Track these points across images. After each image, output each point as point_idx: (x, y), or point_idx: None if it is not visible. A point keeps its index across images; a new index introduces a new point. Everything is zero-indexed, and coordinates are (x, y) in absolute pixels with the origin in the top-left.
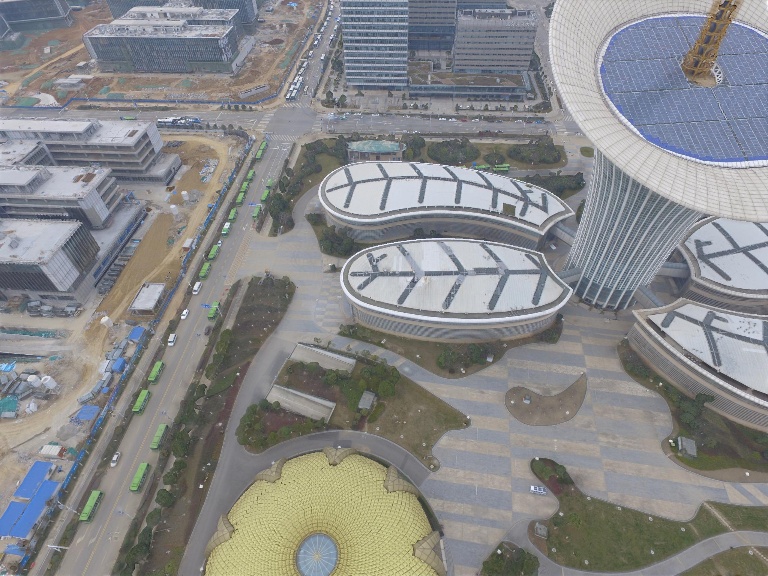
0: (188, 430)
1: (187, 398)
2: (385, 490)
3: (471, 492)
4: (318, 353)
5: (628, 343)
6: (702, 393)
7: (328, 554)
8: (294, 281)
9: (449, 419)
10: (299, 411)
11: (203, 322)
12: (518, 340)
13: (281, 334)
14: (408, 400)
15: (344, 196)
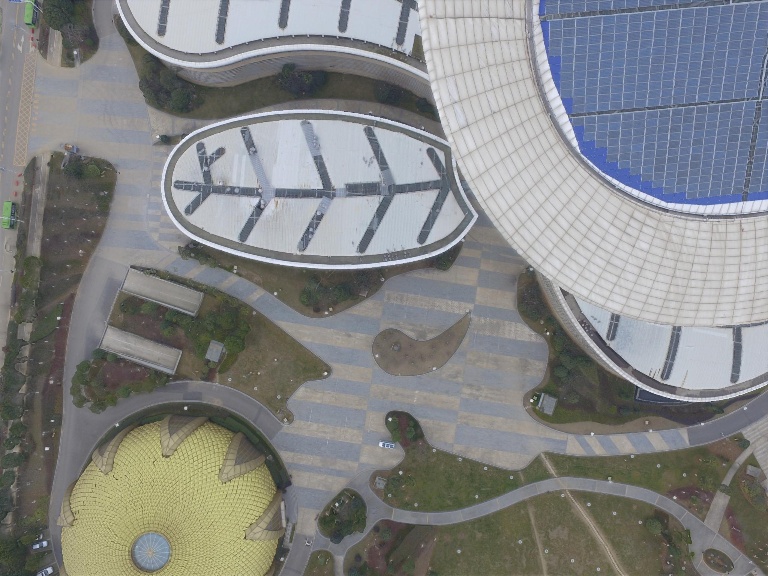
0: (16, 390)
1: (9, 343)
2: (219, 481)
3: (322, 445)
4: (157, 280)
5: (533, 273)
6: (587, 347)
7: (161, 550)
8: (112, 161)
9: (308, 368)
10: (143, 355)
11: (1, 231)
12: (403, 265)
13: (107, 252)
14: (264, 347)
15: (155, 6)
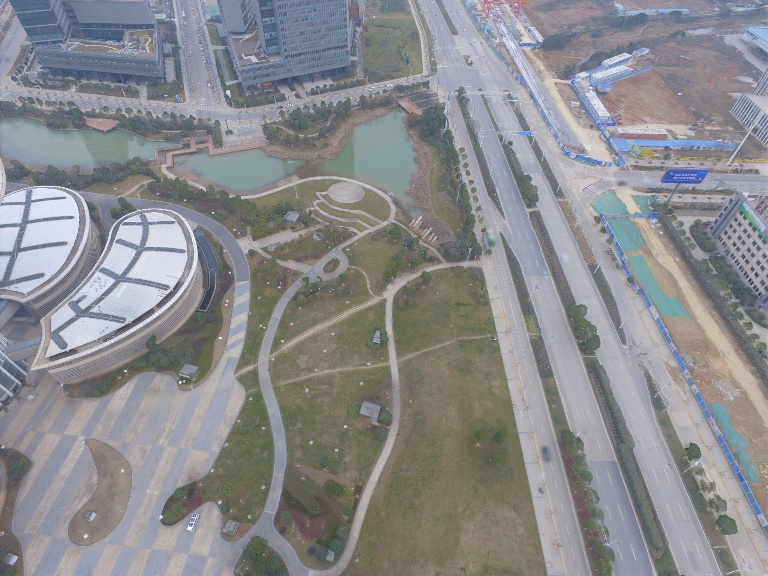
0: None
1: None
2: None
3: None
4: None
5: (69, 385)
6: (146, 342)
7: None
8: None
9: None
10: None
11: None
12: (3, 513)
13: None
14: None
15: None
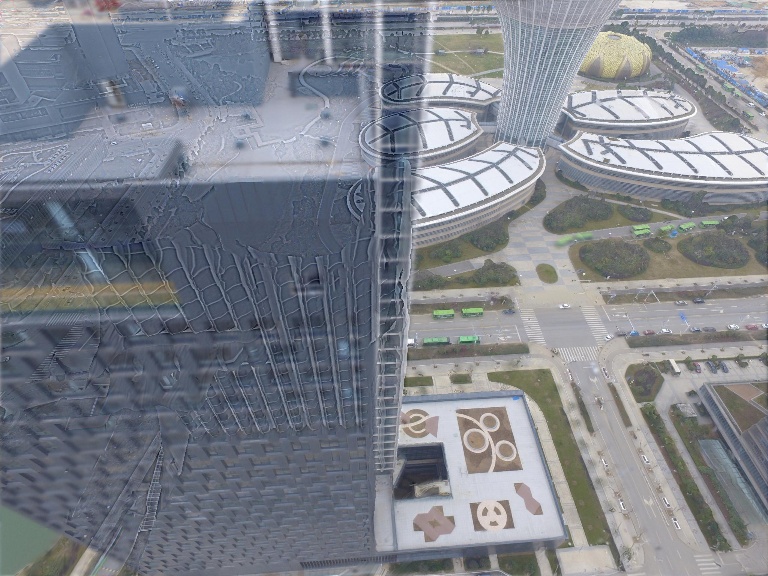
0: None
1: None
2: None
3: None
4: None
5: None
6: None
7: None
8: None
9: None
10: None
11: None
12: None
13: None
14: None
15: (753, 141)
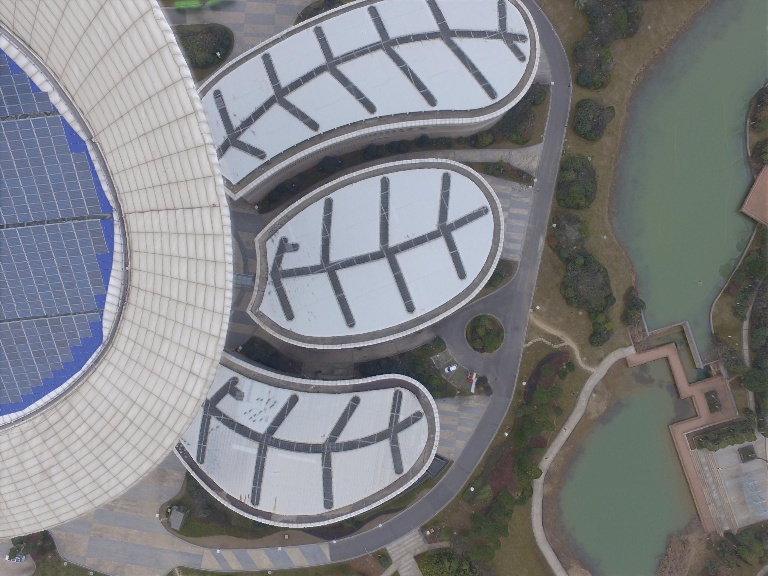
0: None
1: None
2: None
3: None
4: None
5: None
6: None
7: None
8: None
9: None
10: None
11: None
12: None
13: None
14: None
15: None
